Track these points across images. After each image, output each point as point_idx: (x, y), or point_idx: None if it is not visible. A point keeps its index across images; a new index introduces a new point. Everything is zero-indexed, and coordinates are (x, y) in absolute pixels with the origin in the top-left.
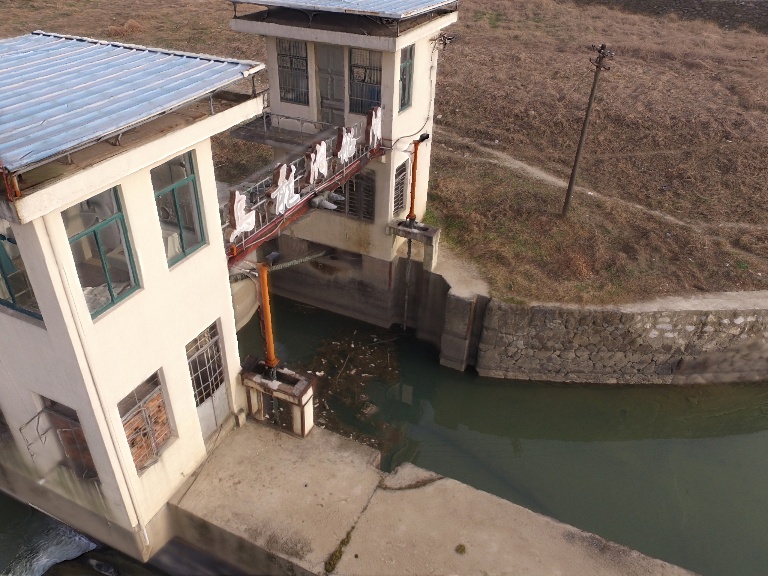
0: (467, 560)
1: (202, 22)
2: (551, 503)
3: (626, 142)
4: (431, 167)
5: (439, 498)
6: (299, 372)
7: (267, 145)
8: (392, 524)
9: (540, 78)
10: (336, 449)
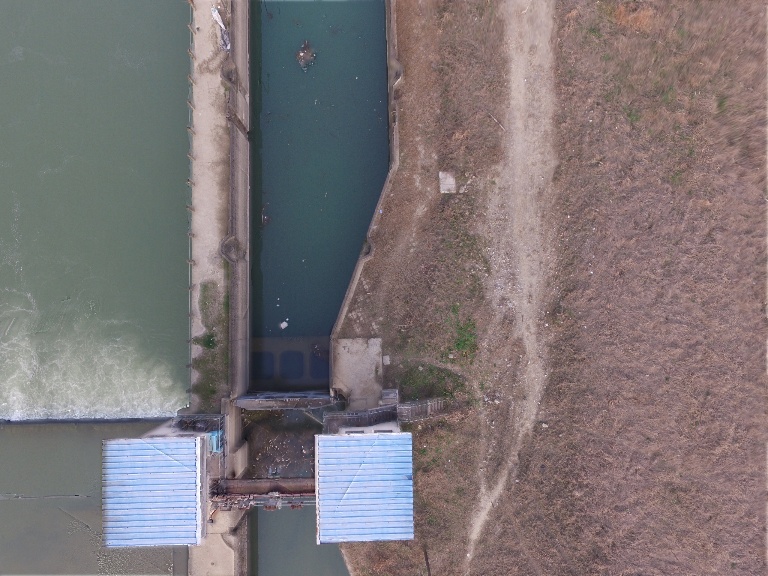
0: (210, 567)
1: (703, 62)
2: (290, 555)
3: (557, 567)
4: (455, 455)
5: (226, 552)
6: (300, 443)
7: (437, 340)
8: (211, 543)
9: (666, 479)
10: (228, 514)
